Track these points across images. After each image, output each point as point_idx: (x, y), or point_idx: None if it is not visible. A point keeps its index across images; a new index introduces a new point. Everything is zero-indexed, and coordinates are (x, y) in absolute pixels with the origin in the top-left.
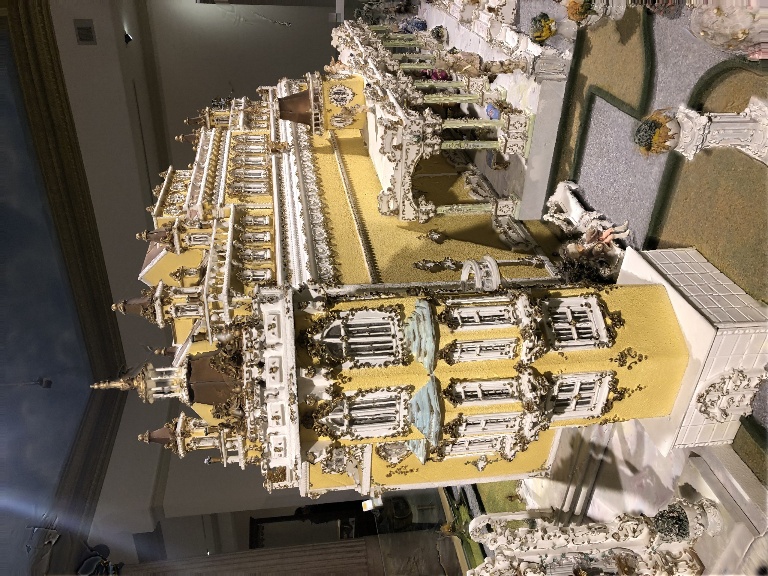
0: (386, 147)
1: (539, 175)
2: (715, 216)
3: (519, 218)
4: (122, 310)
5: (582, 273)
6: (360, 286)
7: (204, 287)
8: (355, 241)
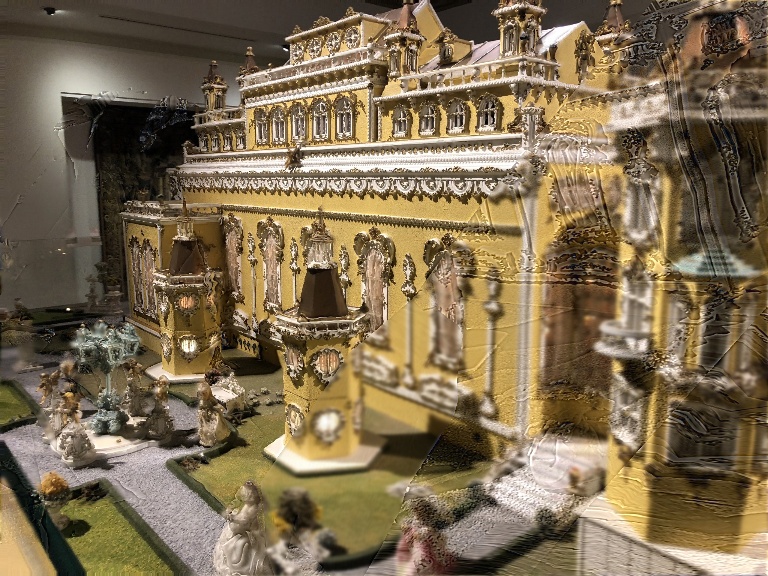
0: None
1: None
2: None
3: None
4: (619, 3)
5: None
6: None
7: None
8: None
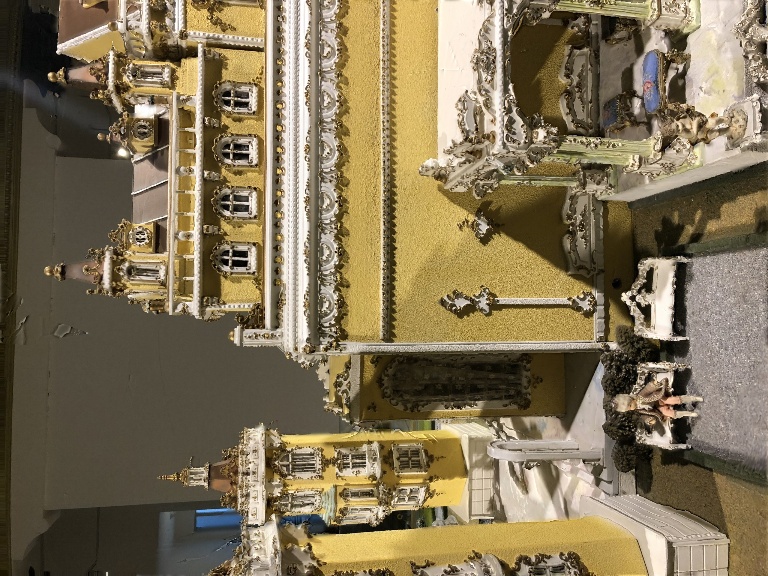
0: (456, 151)
1: (659, 187)
2: (765, 573)
3: (603, 199)
4: None
5: (622, 389)
6: (366, 347)
7: (169, 290)
8: (375, 226)
